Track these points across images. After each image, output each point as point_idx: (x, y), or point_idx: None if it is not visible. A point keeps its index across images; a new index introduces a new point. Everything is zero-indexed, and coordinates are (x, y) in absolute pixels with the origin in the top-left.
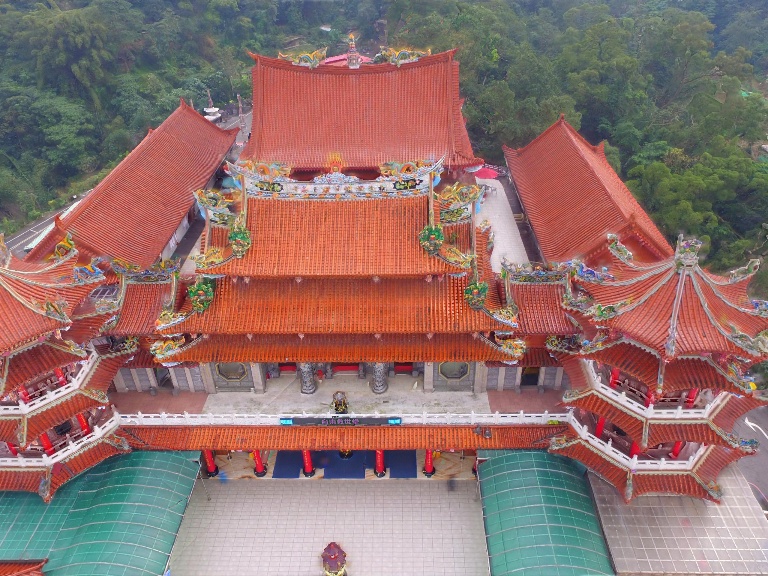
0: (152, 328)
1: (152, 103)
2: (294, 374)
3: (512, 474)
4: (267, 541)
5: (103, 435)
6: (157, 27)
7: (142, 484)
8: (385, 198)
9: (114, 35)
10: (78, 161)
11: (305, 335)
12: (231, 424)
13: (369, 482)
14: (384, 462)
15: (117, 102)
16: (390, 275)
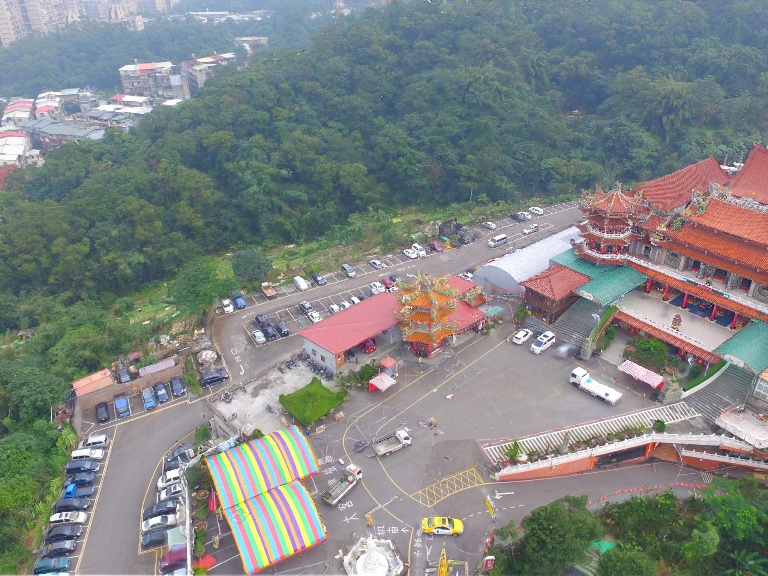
0: (654, 230)
1: (702, 150)
2: (697, 272)
3: (761, 326)
4: (656, 314)
5: (620, 258)
6: (732, 102)
7: (627, 274)
8: (767, 214)
9: (699, 103)
10: (640, 172)
11: (708, 254)
12: (664, 273)
13: (705, 320)
14: (716, 317)
15: (680, 144)
16: (751, 240)
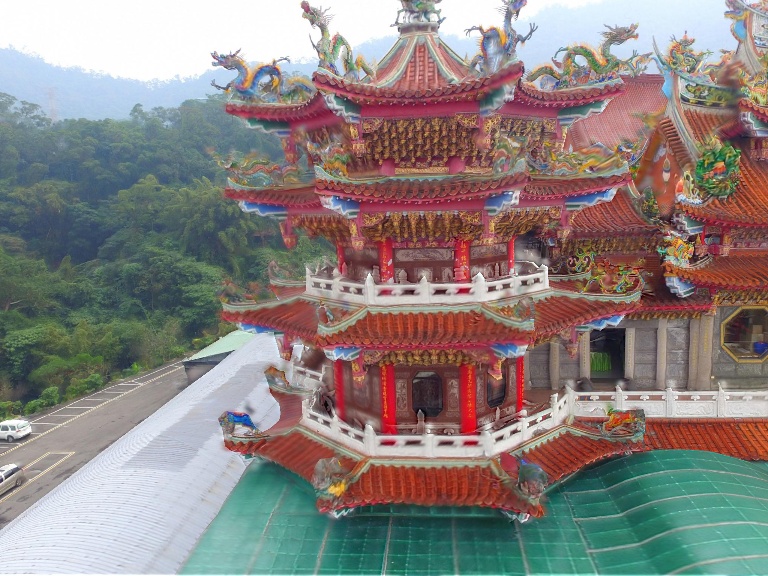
0: (633, 226)
1: None
2: None
3: None
4: None
5: (561, 422)
6: None
7: (744, 494)
8: None
9: None
10: (214, 319)
11: None
12: None
13: None
14: None
15: (255, 271)
16: None
